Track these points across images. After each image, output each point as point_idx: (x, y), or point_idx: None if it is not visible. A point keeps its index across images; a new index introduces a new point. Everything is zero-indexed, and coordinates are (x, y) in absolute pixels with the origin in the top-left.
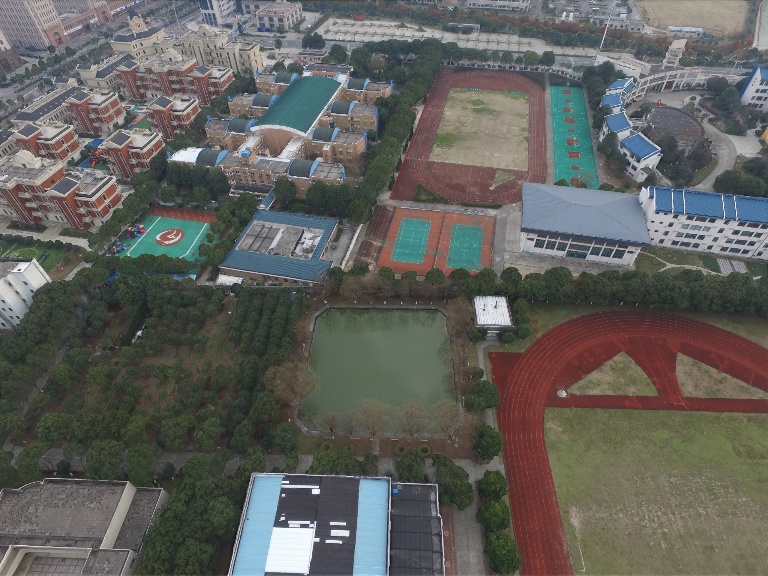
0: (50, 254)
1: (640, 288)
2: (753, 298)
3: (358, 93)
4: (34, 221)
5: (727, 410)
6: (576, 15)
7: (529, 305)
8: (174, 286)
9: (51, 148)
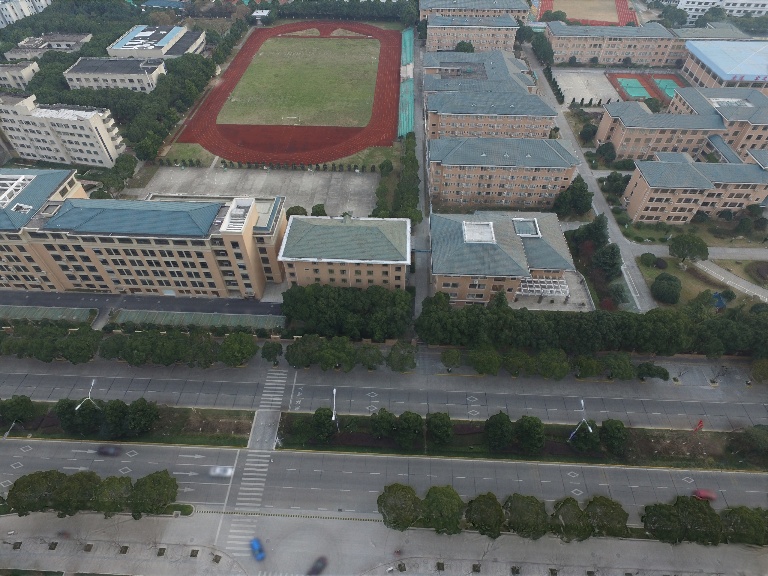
0: None
1: (327, 3)
2: (374, 6)
3: None
4: None
5: (344, 38)
6: None
7: None
8: (117, 4)
9: None
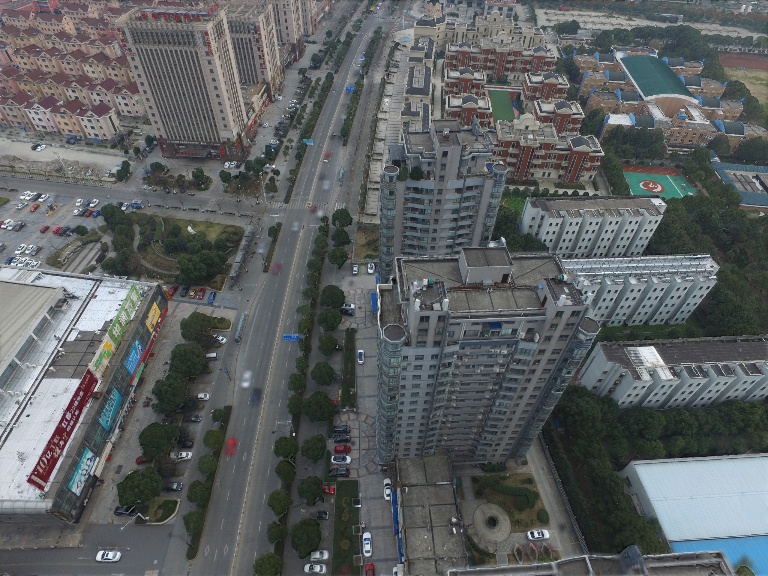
0: None
1: None
2: None
3: (681, 70)
4: (527, 177)
5: None
6: (745, 8)
7: None
8: None
9: (485, 117)
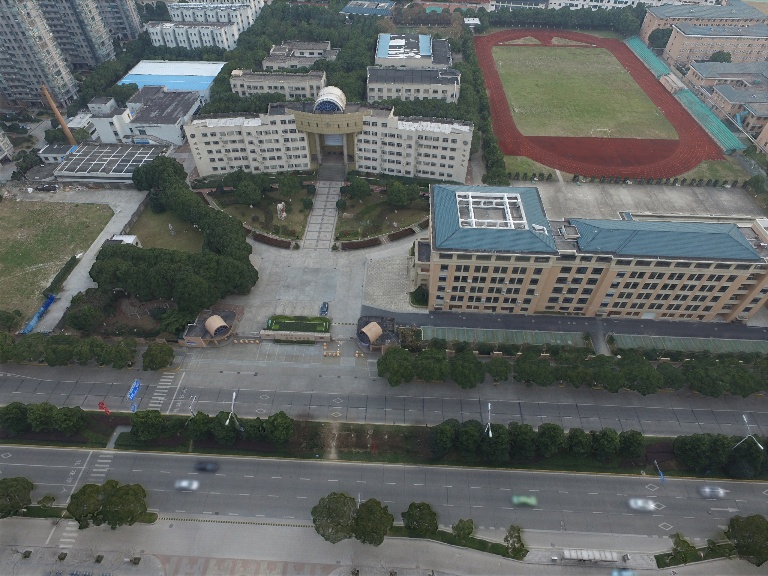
0: None
1: (539, 11)
2: (589, 14)
3: None
4: None
5: None
6: None
7: (490, 27)
8: (323, 11)
9: None
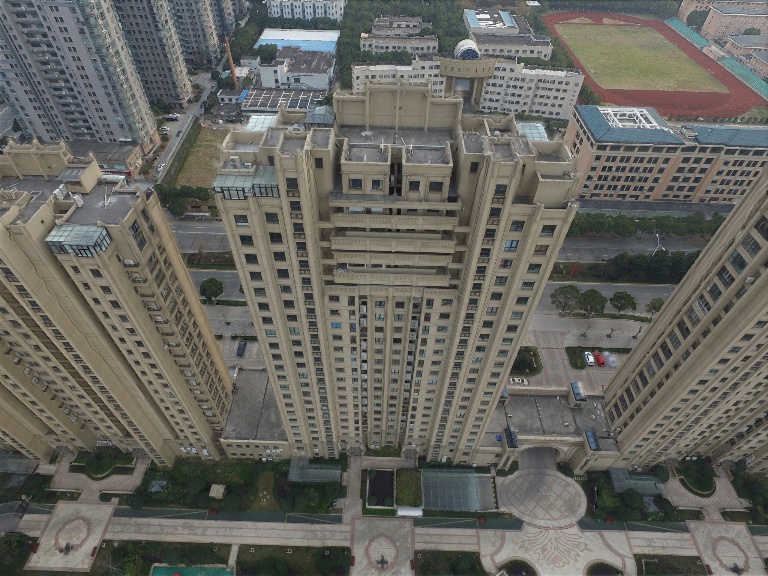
0: None
1: None
2: None
3: None
4: None
5: (619, 25)
6: None
7: None
8: None
9: None
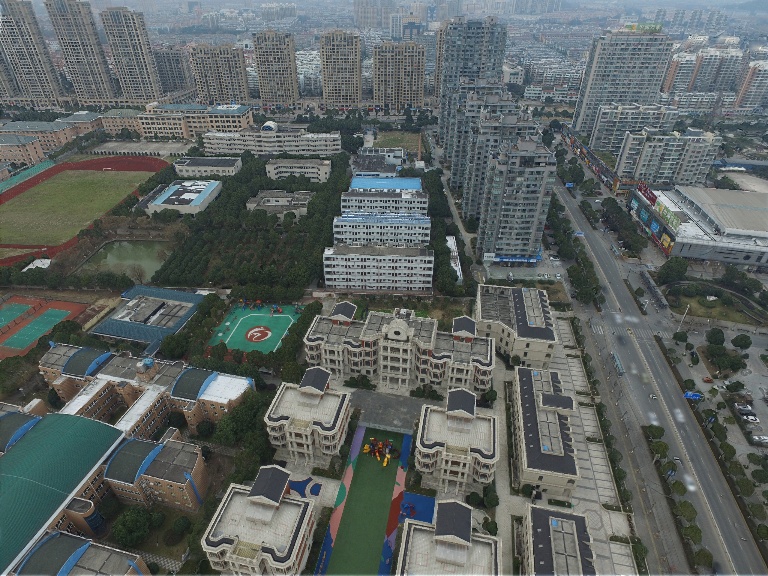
0: (361, 320)
1: None
2: None
3: None
4: None
5: None
6: None
7: None
8: None
9: None
